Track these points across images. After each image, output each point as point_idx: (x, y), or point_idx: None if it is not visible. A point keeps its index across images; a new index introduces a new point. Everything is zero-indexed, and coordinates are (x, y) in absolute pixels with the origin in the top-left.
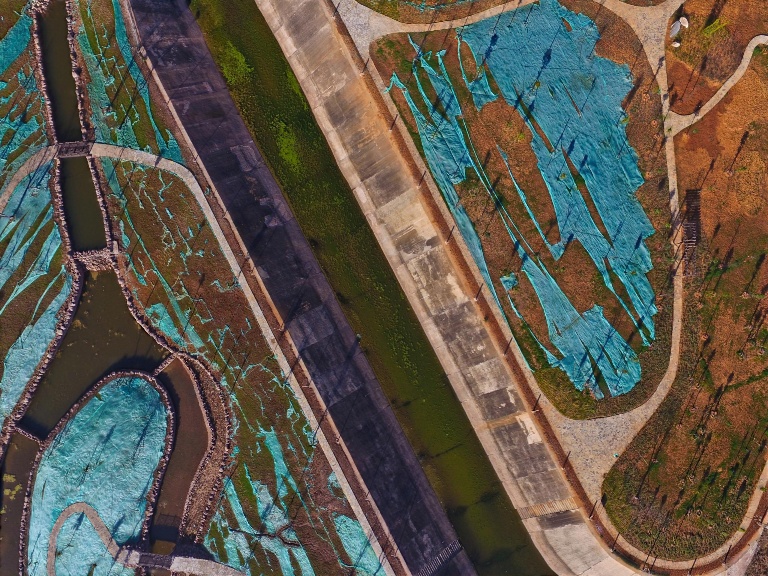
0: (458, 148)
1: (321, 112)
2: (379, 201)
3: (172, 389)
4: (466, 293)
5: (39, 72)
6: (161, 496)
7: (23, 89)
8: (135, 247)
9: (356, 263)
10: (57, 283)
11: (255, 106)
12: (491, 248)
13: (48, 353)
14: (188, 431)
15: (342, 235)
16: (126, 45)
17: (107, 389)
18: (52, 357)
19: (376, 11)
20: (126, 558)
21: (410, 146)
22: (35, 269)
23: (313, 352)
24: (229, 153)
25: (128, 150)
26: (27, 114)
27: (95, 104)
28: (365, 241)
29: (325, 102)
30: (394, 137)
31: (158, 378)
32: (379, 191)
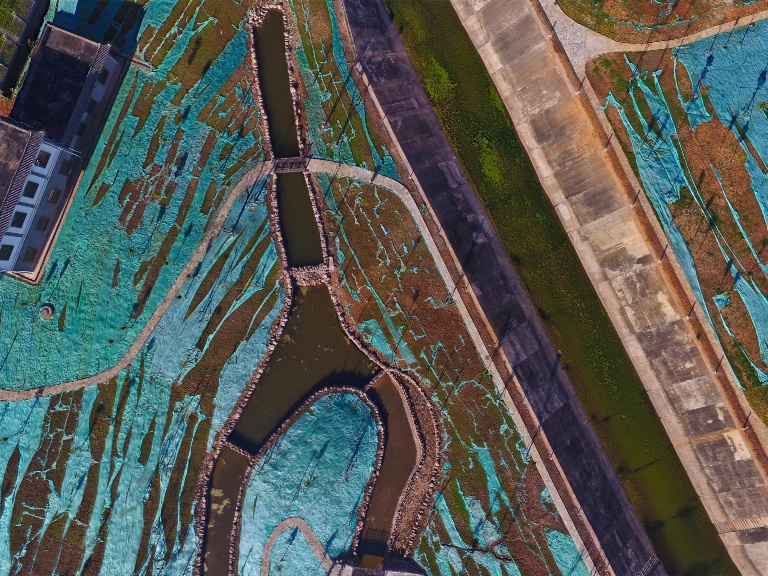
0: (673, 168)
1: (526, 129)
2: (585, 219)
3: (381, 404)
4: (678, 311)
5: (256, 87)
6: (369, 511)
7: (241, 104)
8: (349, 263)
9: (557, 280)
10: (271, 298)
11: (458, 122)
12: (704, 267)
13: (260, 368)
14: (396, 446)
15: (544, 252)
16: (343, 60)
17: (319, 404)
18: (262, 372)
19: (593, 30)
20: (339, 573)
21: (625, 165)
22: (252, 284)
23: (524, 369)
24: (438, 169)
25: (344, 166)
26: (244, 129)
27: (312, 119)
28: (567, 258)
29: (531, 119)
30: (609, 156)
31: (367, 393)
32: (586, 209)
